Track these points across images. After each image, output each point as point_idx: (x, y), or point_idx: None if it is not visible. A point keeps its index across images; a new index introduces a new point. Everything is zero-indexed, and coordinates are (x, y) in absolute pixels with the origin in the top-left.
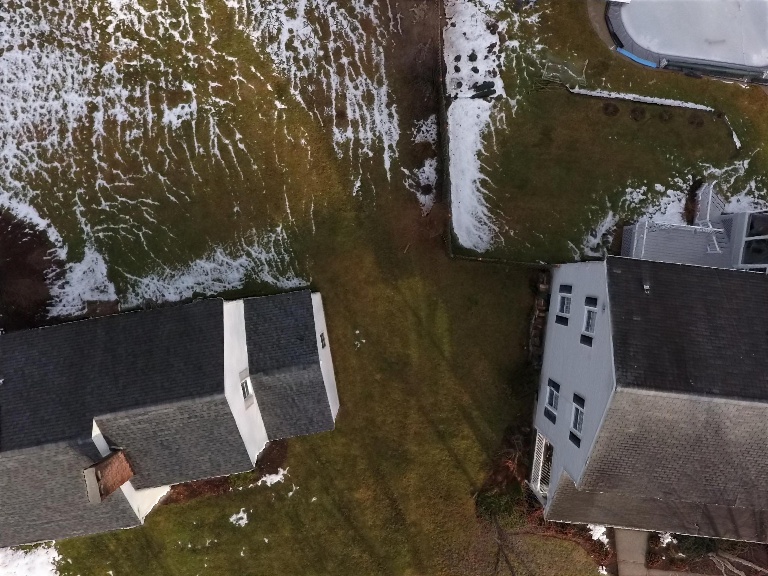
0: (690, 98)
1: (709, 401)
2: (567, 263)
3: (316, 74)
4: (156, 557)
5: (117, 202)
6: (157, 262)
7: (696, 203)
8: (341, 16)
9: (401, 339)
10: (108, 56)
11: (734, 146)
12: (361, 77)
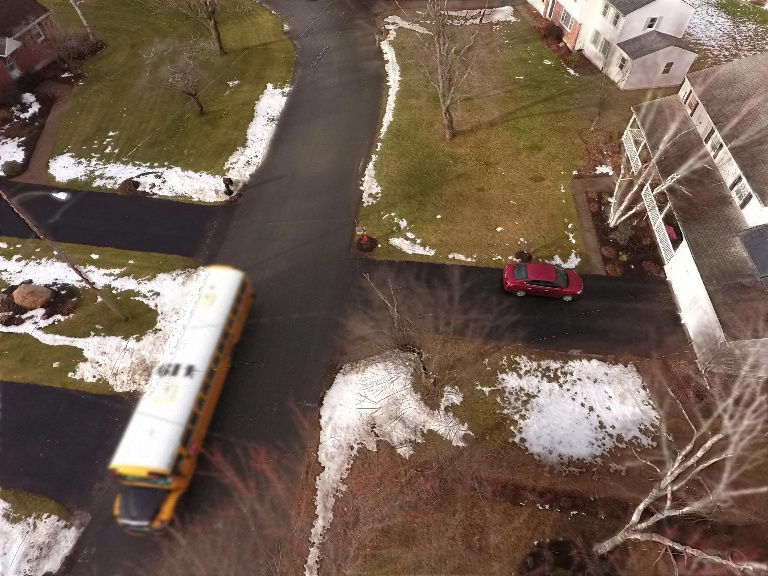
0: None
1: None
2: None
3: None
4: (520, 41)
5: None
6: None
7: None
8: None
9: None
10: (740, 51)
11: None
12: None
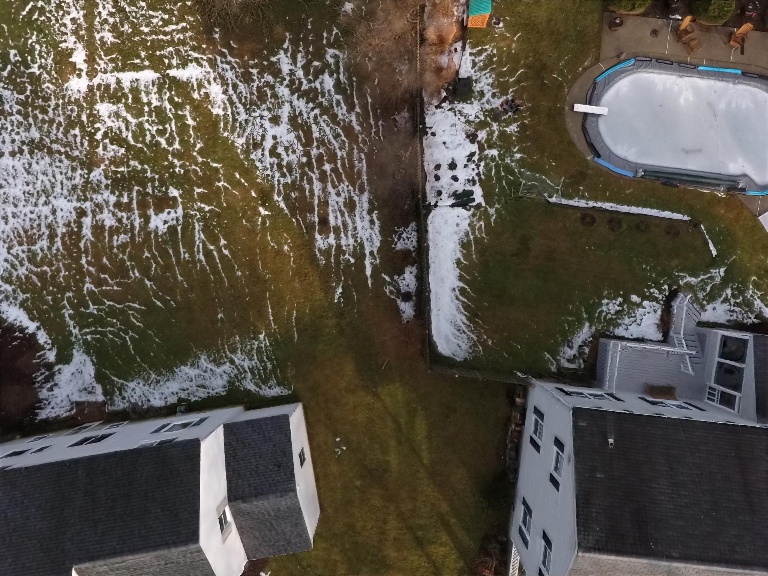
0: (667, 207)
1: (669, 565)
2: (541, 386)
3: (299, 180)
4: None
5: (105, 306)
6: (143, 367)
7: (671, 315)
8: (324, 123)
9: (381, 446)
10: (96, 162)
11: (710, 255)
12: (343, 184)
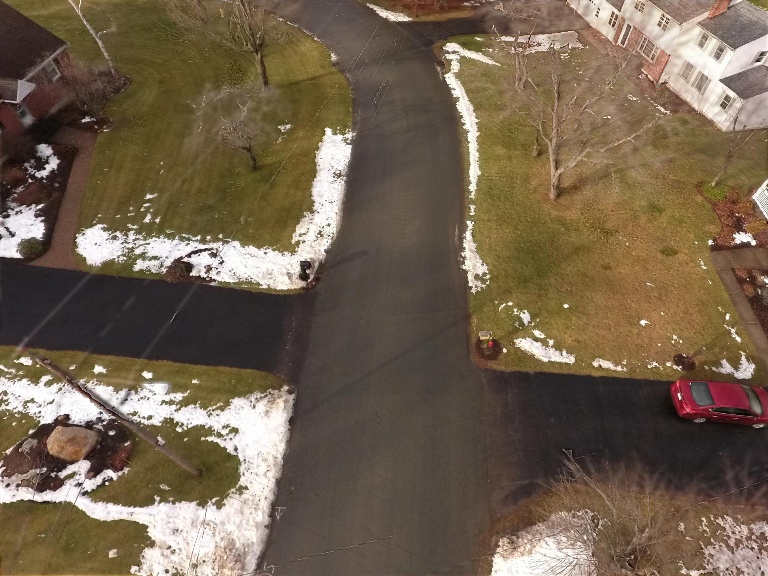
0: None
1: None
2: None
3: None
4: None
5: None
6: None
7: None
8: None
9: None
10: None
11: None
12: None
